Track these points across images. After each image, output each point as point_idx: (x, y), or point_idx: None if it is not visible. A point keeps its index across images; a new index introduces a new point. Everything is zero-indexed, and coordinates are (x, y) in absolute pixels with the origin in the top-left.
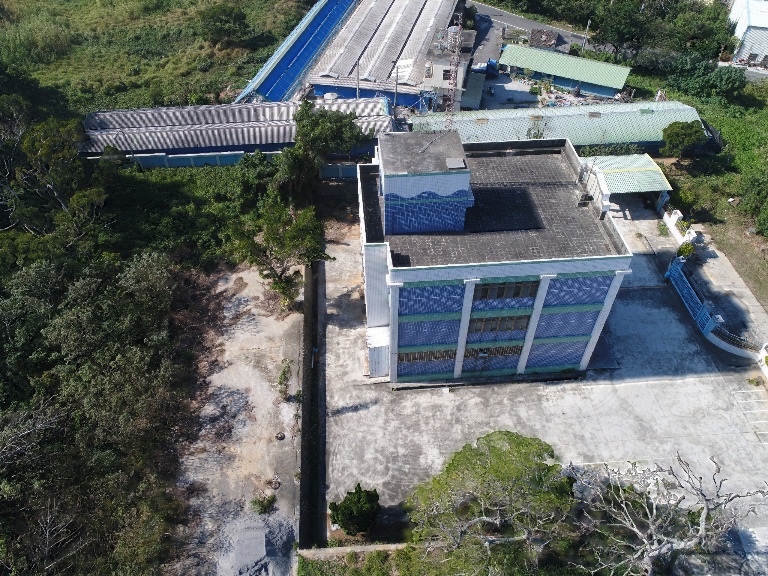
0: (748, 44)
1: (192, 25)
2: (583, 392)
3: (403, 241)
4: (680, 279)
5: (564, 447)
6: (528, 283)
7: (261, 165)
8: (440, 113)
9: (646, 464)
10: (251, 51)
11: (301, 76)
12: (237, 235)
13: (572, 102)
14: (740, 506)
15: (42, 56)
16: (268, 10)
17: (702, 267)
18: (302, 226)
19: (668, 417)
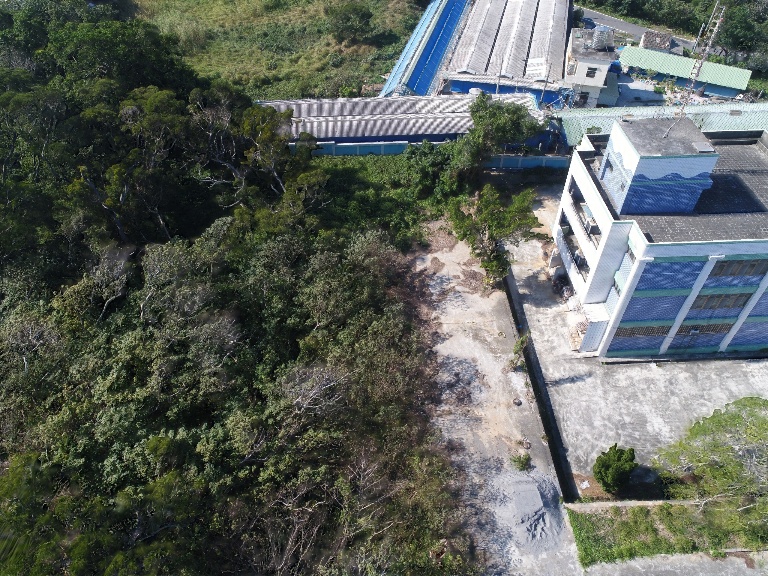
0: None
1: (315, 23)
2: None
3: (638, 220)
4: None
5: None
6: (763, 261)
7: (431, 154)
8: (581, 109)
9: None
10: (377, 48)
11: (438, 72)
12: (459, 215)
13: (698, 101)
14: None
15: (184, 50)
16: (384, 10)
17: None
18: (523, 207)
19: None
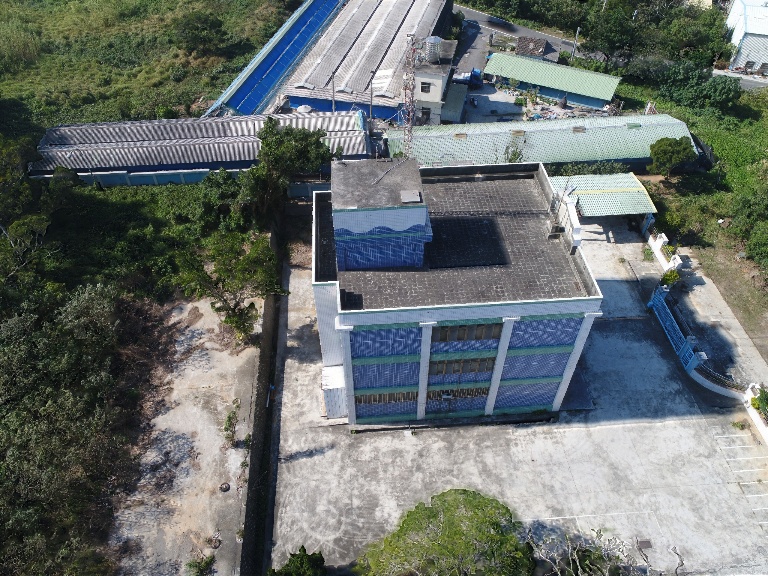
0: (745, 51)
1: (168, 32)
2: (555, 436)
3: (357, 278)
4: (663, 310)
5: (531, 499)
6: (490, 325)
7: (225, 184)
8: (418, 127)
9: (619, 519)
10: (227, 60)
11: (276, 87)
12: (185, 267)
13: (558, 114)
14: (720, 568)
15: (9, 66)
16: (248, 16)
17: (688, 295)
18: (254, 258)
19: (645, 465)
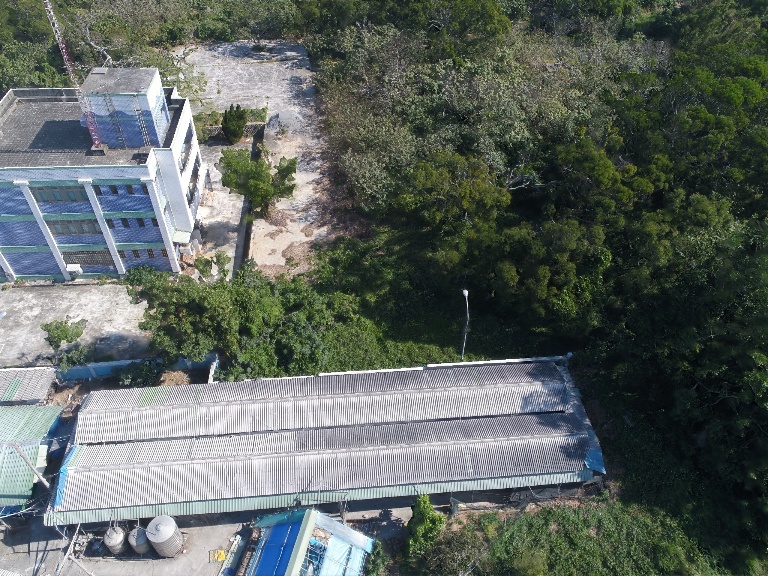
0: None
1: None
2: None
3: None
4: None
5: None
6: None
7: None
8: None
9: None
10: None
11: None
12: None
13: None
14: None
15: None
16: None
17: None
18: (235, 157)
19: None
